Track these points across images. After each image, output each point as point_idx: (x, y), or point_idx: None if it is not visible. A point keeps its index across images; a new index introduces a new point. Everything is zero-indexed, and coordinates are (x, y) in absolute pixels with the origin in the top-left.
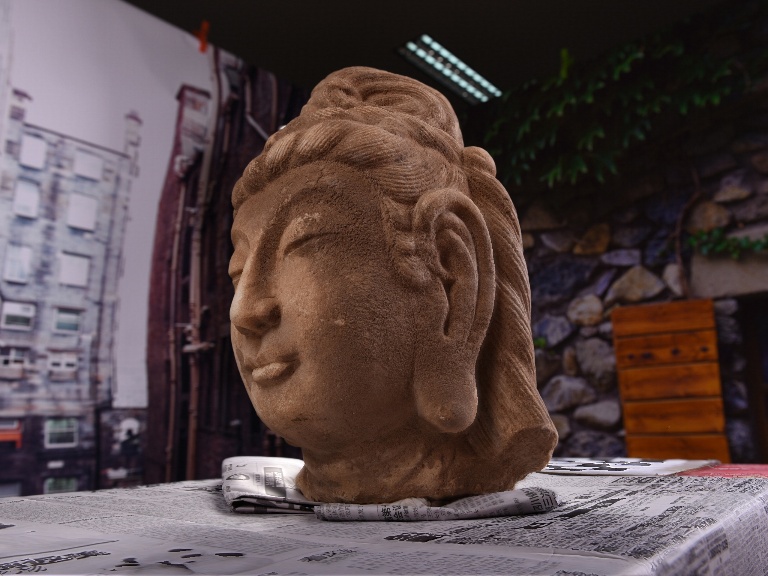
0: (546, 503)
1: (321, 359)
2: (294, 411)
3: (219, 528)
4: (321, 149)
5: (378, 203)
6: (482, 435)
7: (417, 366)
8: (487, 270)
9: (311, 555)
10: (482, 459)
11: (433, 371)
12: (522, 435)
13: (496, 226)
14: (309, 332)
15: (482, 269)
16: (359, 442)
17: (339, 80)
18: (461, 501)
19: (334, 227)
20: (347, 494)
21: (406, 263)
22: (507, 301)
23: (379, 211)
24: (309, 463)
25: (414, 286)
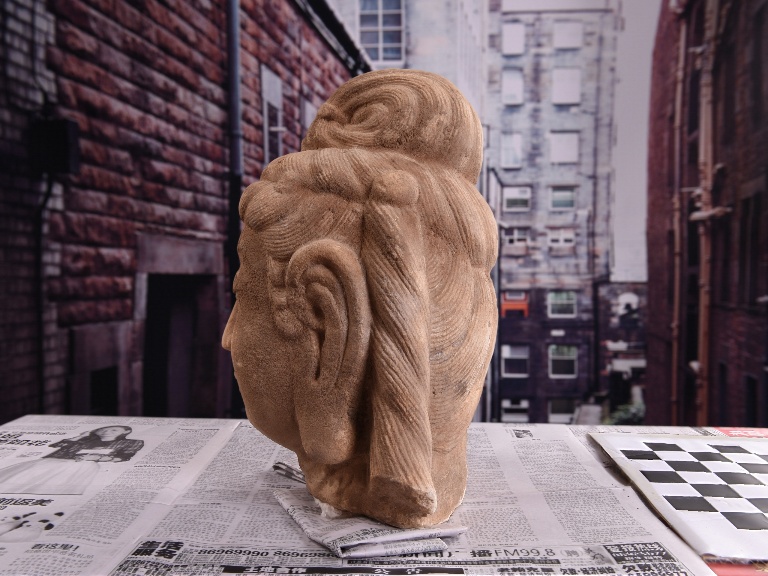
0: None
1: None
2: None
3: (137, 499)
4: None
5: (266, 262)
6: None
7: None
8: (353, 319)
9: (47, 543)
10: (367, 490)
11: (304, 410)
12: (381, 480)
13: (372, 270)
14: None
15: (351, 318)
16: None
17: (323, 108)
18: None
19: (241, 285)
20: None
21: (280, 317)
22: (377, 349)
23: (266, 269)
24: None
25: (287, 337)
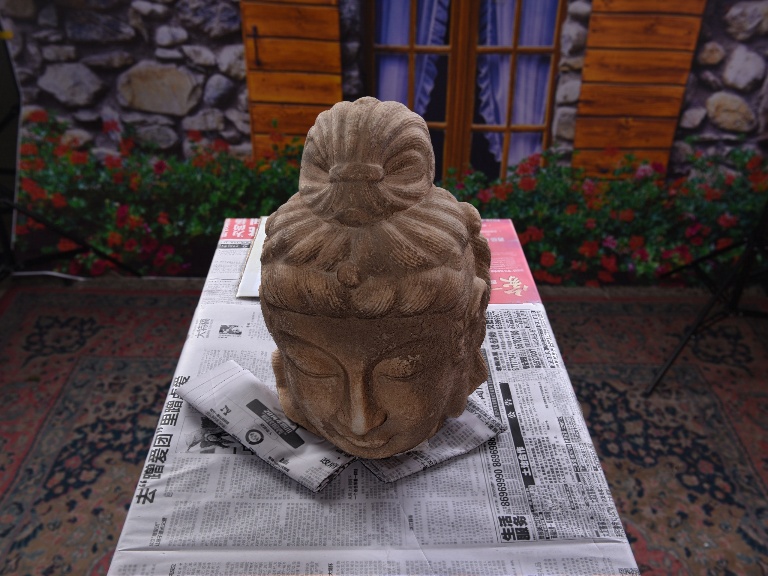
0: None
1: None
2: None
3: (428, 571)
4: None
5: None
6: None
7: None
8: None
9: None
10: None
11: None
12: None
13: None
14: (413, 426)
15: None
16: None
17: (376, 171)
18: (445, 431)
19: None
20: None
21: None
22: None
23: None
24: None
25: None
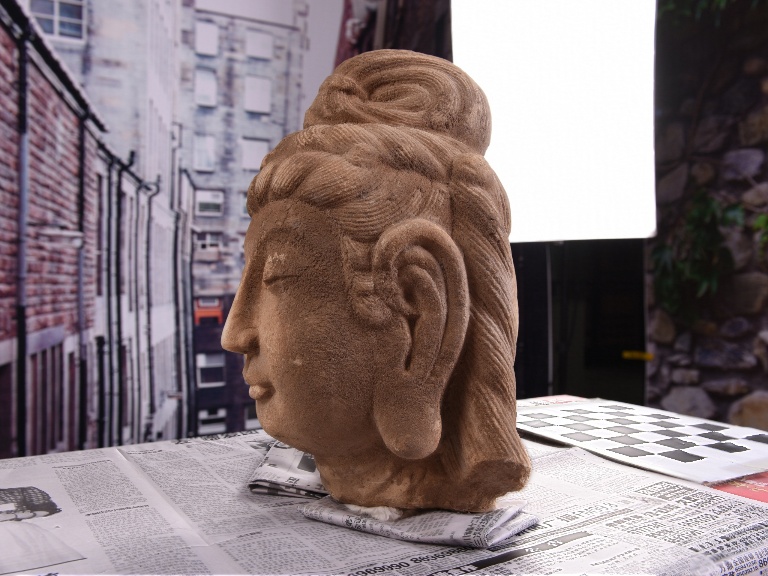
0: (477, 543)
1: (285, 392)
2: (273, 429)
3: (171, 547)
4: (287, 188)
5: (338, 243)
6: (453, 458)
7: (376, 400)
8: (456, 302)
9: None
10: (450, 480)
11: (391, 405)
12: (486, 465)
13: (474, 252)
14: (275, 368)
15: (451, 301)
16: (336, 456)
17: (339, 79)
18: (426, 516)
19: (295, 270)
20: (334, 494)
21: (363, 304)
22: (480, 332)
23: (339, 251)
24: (314, 457)
25: (372, 325)
